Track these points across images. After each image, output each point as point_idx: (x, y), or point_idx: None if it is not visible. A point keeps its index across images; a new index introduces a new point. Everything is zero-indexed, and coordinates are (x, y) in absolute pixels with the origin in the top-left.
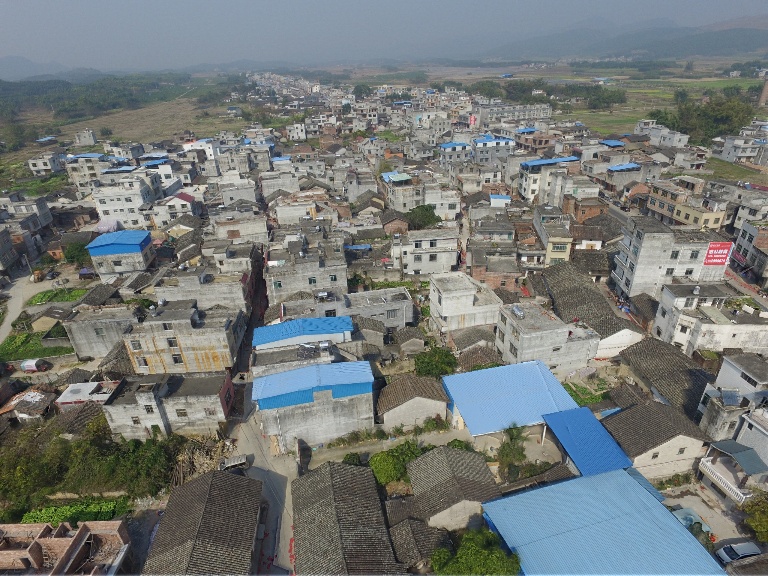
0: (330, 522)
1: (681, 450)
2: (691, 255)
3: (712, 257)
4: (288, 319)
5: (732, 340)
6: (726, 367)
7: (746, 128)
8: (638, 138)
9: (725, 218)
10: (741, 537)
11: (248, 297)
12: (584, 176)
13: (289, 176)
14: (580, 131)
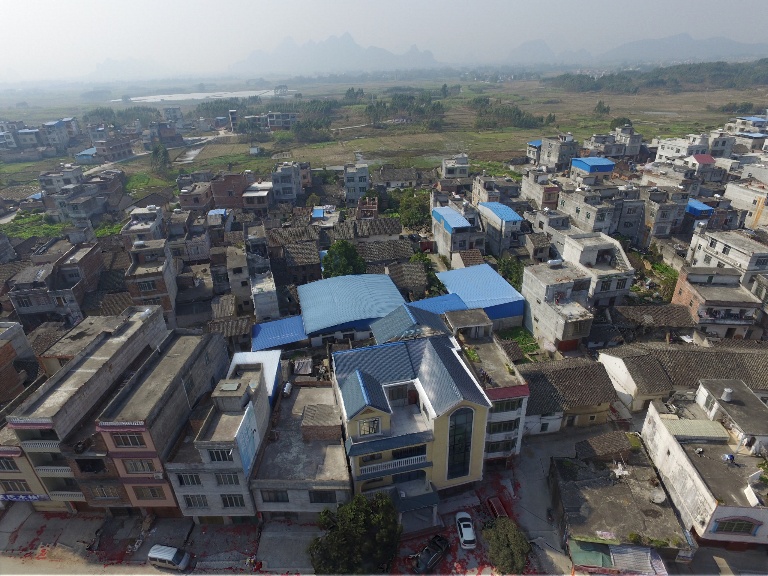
0: None
1: None
2: None
3: None
4: (519, 211)
5: (666, 458)
6: None
7: None
8: None
9: None
10: None
11: (550, 204)
12: None
13: None
14: None
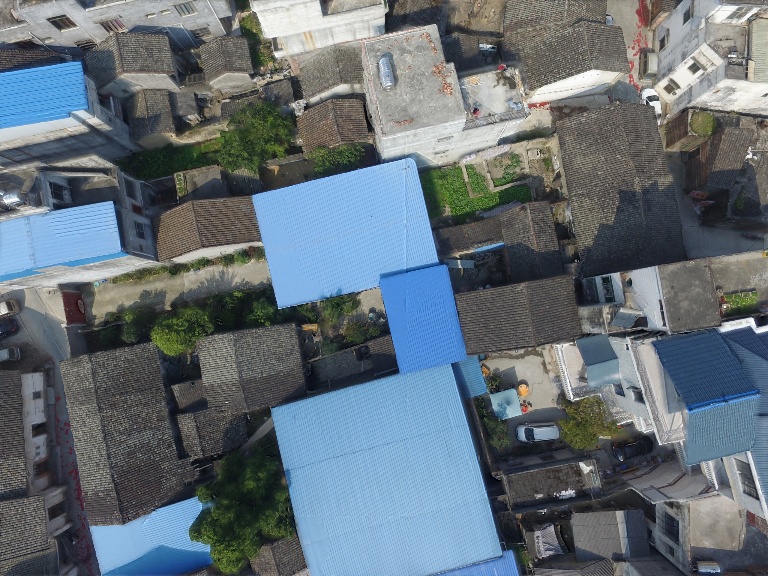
0: (98, 435)
1: None
2: None
3: None
4: None
5: (758, 99)
6: (652, 275)
7: None
8: None
9: None
10: (556, 407)
11: None
12: None
13: None
14: None
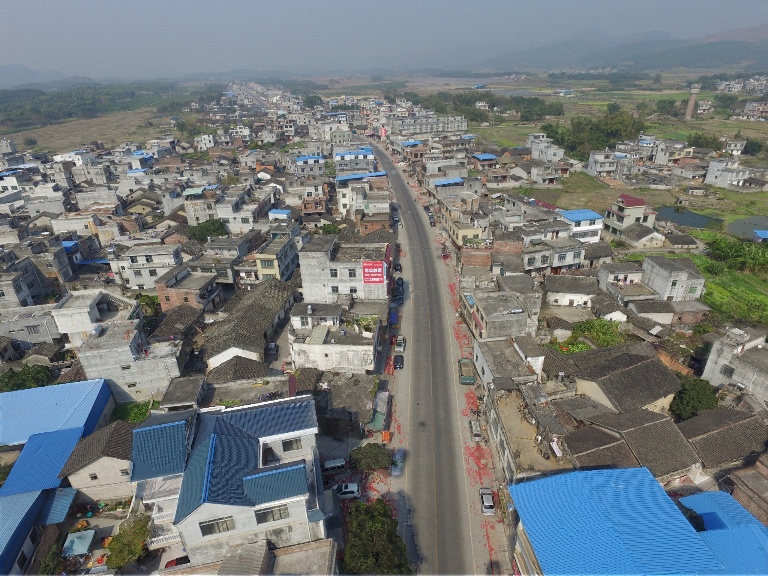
0: None
1: (123, 471)
2: (349, 274)
3: (369, 276)
4: None
5: (326, 360)
6: None
7: (621, 142)
8: (519, 152)
9: (490, 234)
10: None
11: None
12: (385, 191)
13: (105, 189)
14: (463, 144)
